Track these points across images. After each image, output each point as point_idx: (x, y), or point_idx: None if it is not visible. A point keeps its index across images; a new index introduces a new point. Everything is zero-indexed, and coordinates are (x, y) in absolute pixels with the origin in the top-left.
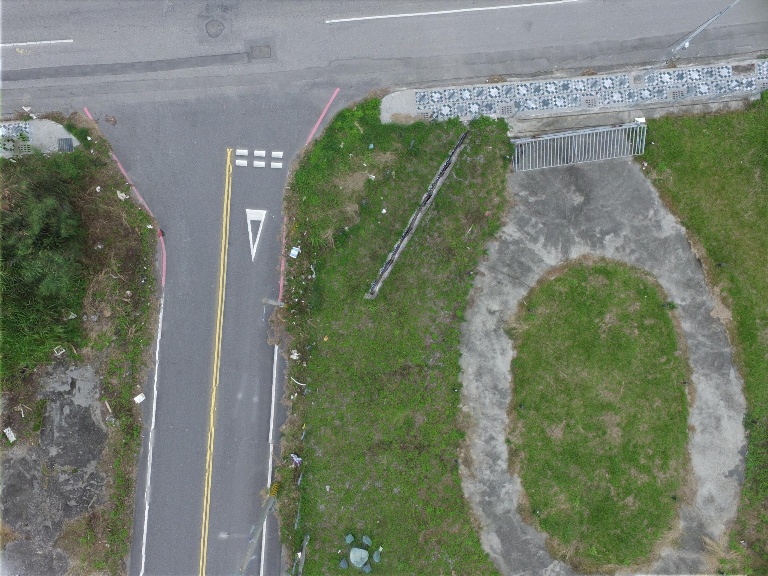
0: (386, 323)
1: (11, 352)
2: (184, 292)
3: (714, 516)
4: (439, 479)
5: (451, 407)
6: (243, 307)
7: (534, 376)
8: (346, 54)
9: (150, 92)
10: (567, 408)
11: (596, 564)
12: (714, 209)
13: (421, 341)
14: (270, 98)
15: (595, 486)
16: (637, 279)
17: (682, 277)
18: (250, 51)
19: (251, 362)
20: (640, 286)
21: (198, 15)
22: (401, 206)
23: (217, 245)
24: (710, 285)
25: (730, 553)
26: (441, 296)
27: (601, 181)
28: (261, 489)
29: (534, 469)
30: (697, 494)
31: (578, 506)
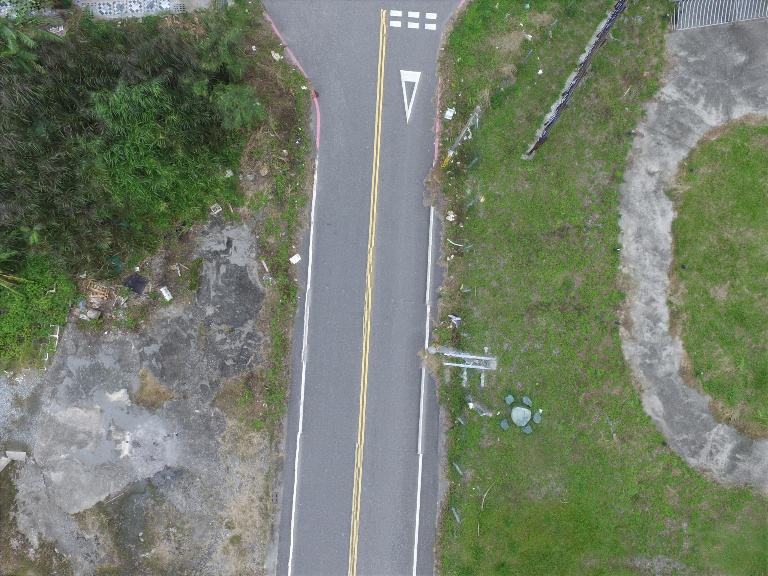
0: (544, 184)
1: (177, 201)
2: (339, 153)
3: None
4: (599, 341)
5: (611, 268)
6: (398, 168)
7: (697, 236)
8: None
9: None
10: (731, 268)
11: (761, 428)
12: None
13: (580, 202)
14: None
15: (760, 348)
16: None
17: None
18: None
19: (407, 223)
20: None
21: None
22: (558, 67)
23: (372, 106)
24: None
25: None
26: (600, 157)
27: (762, 41)
28: (418, 350)
29: (697, 330)
30: None
31: (742, 369)
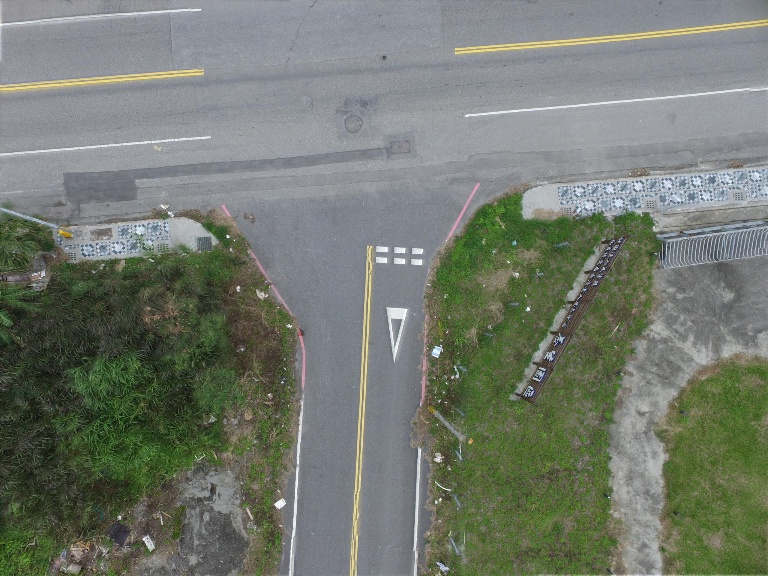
0: (533, 425)
1: (159, 463)
2: (324, 393)
3: None
4: None
5: (602, 513)
6: (385, 409)
7: (688, 481)
8: (486, 148)
9: (289, 189)
10: (724, 515)
11: None
12: None
13: (569, 444)
14: (410, 193)
15: None
16: None
17: None
18: (389, 146)
19: (394, 466)
20: None
21: (336, 110)
22: (545, 304)
23: (358, 345)
24: None
25: None
26: (589, 397)
27: (751, 277)
28: None
29: None
30: None
31: None
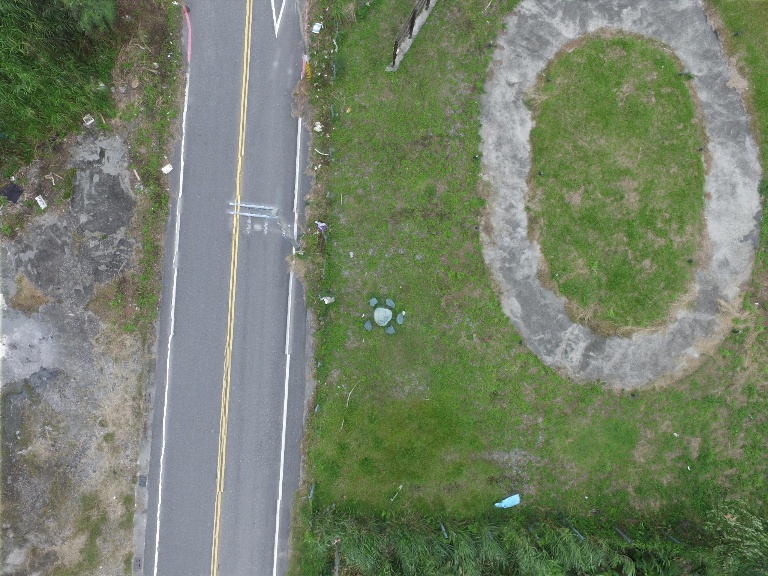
0: (407, 95)
1: (43, 108)
2: (209, 66)
3: (729, 280)
4: (460, 245)
5: (472, 175)
6: (267, 81)
7: (553, 144)
8: None
9: None
10: (585, 174)
11: (614, 327)
12: None
13: (442, 112)
14: None
15: (613, 251)
16: (654, 50)
17: (698, 49)
18: None
19: (275, 134)
20: (657, 57)
21: None
22: None
23: (241, 20)
24: (726, 56)
25: (745, 314)
26: (461, 68)
27: None
28: (286, 256)
29: (553, 234)
30: (713, 259)
31: (596, 271)
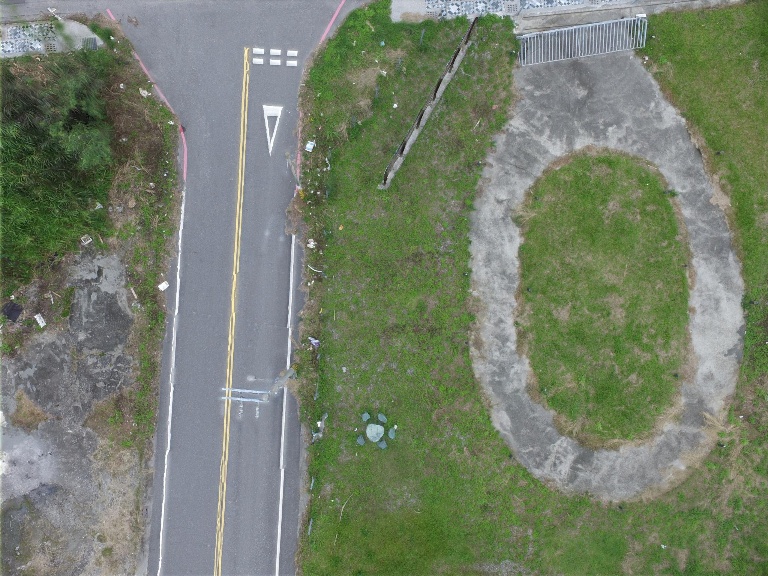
0: (398, 212)
1: (42, 235)
2: (205, 185)
3: (714, 393)
4: (451, 360)
5: (461, 291)
6: (261, 199)
7: (541, 261)
8: None
9: None
10: (573, 290)
11: (601, 440)
12: (713, 100)
13: (432, 229)
14: None
15: (600, 365)
16: (639, 168)
17: (682, 166)
18: None
19: (269, 251)
20: (642, 174)
21: None
22: (412, 101)
23: (236, 140)
24: (709, 173)
25: (730, 427)
26: (451, 186)
27: (604, 75)
28: (280, 371)
29: (541, 349)
30: (698, 372)
31: (584, 385)
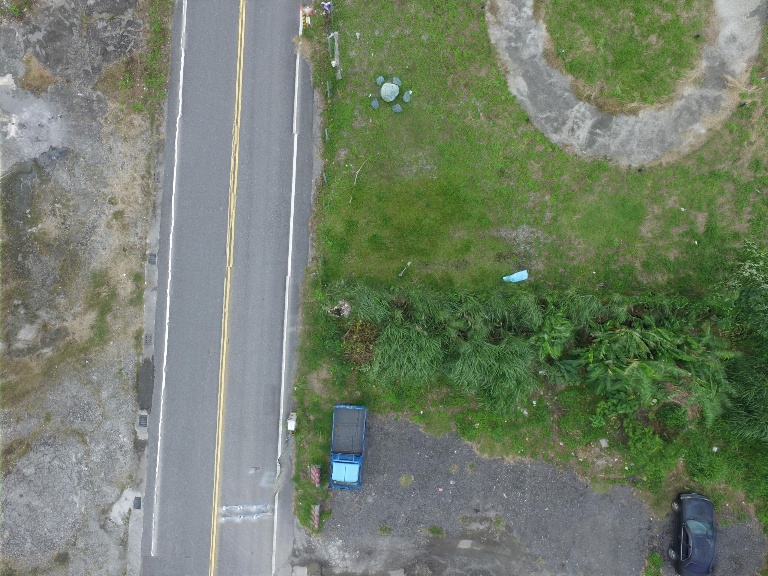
0: None
1: None
2: None
3: (736, 55)
4: (466, 25)
5: None
6: None
7: None
8: None
9: None
10: None
11: (620, 104)
12: None
13: None
14: None
15: (619, 28)
16: None
17: None
18: None
19: None
20: None
21: None
22: None
23: None
24: None
25: (752, 89)
26: None
27: None
28: (293, 37)
29: (559, 11)
30: (719, 35)
31: (602, 49)
